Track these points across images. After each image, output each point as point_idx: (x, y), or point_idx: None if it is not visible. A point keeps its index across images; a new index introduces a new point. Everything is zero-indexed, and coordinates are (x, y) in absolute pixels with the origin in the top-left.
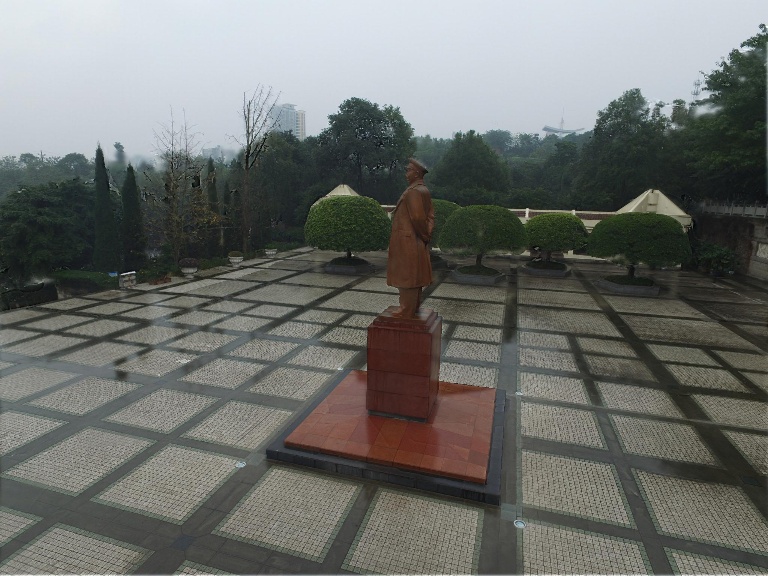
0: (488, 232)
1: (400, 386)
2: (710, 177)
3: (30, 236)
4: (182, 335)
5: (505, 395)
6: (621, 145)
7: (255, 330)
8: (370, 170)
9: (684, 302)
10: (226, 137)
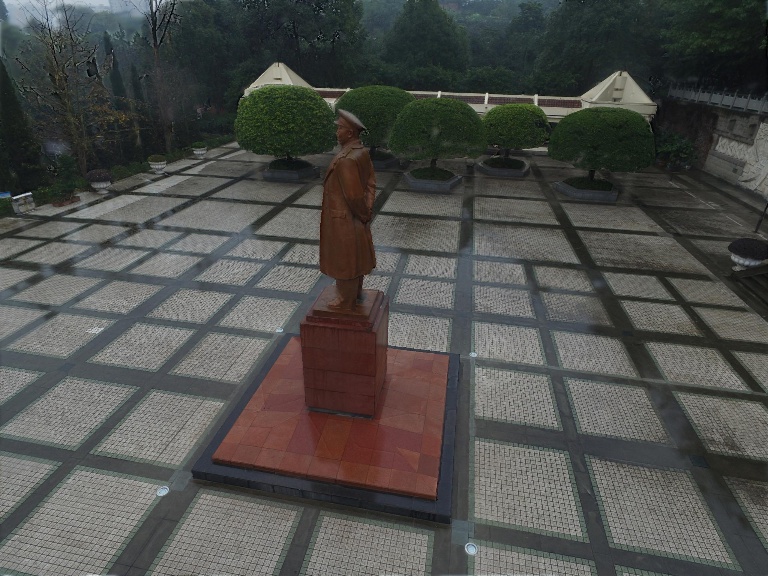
0: (444, 133)
1: (342, 385)
2: (682, 58)
3: None
4: (93, 288)
5: (459, 362)
6: (593, 15)
7: (181, 275)
8: None
9: (641, 210)
10: (122, 3)
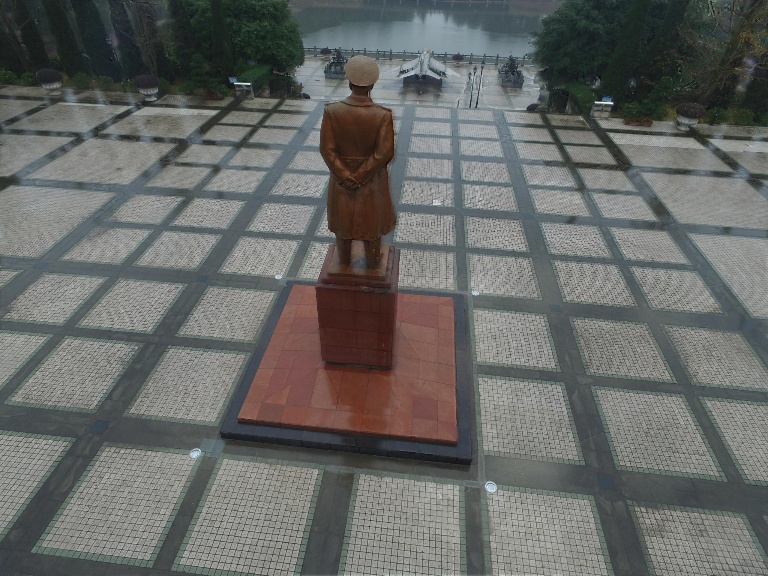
0: None
1: None
2: None
3: (565, 40)
4: (494, 183)
5: (450, 455)
6: None
7: (544, 214)
8: None
9: None
10: None
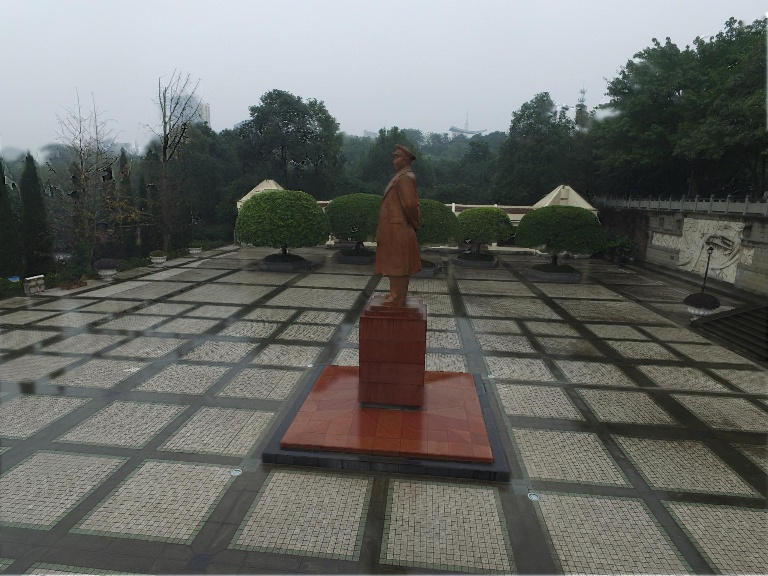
0: (426, 225)
1: (394, 376)
2: (611, 174)
3: None
4: (121, 342)
5: (481, 378)
6: (535, 144)
7: (204, 332)
8: (295, 165)
9: (602, 286)
10: (140, 126)
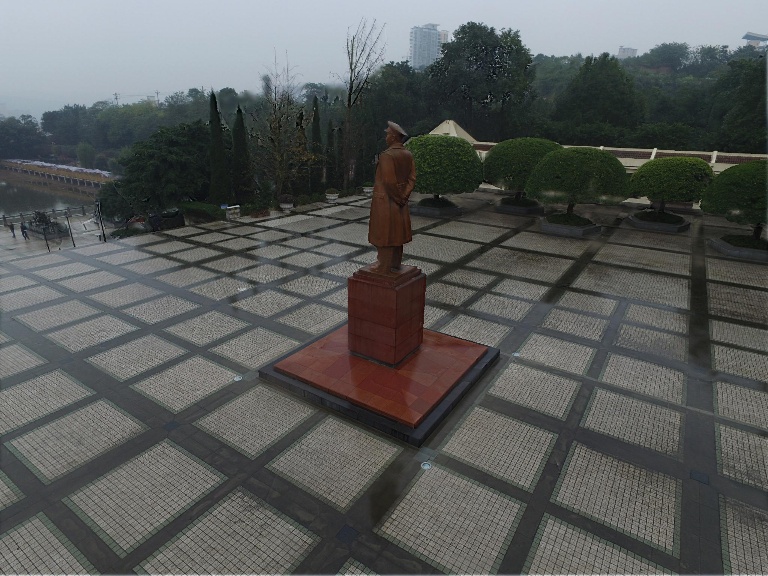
0: (578, 179)
1: (373, 333)
2: None
3: (163, 172)
4: (252, 266)
5: (495, 354)
6: None
7: (312, 267)
8: (483, 103)
9: None
10: (330, 75)
